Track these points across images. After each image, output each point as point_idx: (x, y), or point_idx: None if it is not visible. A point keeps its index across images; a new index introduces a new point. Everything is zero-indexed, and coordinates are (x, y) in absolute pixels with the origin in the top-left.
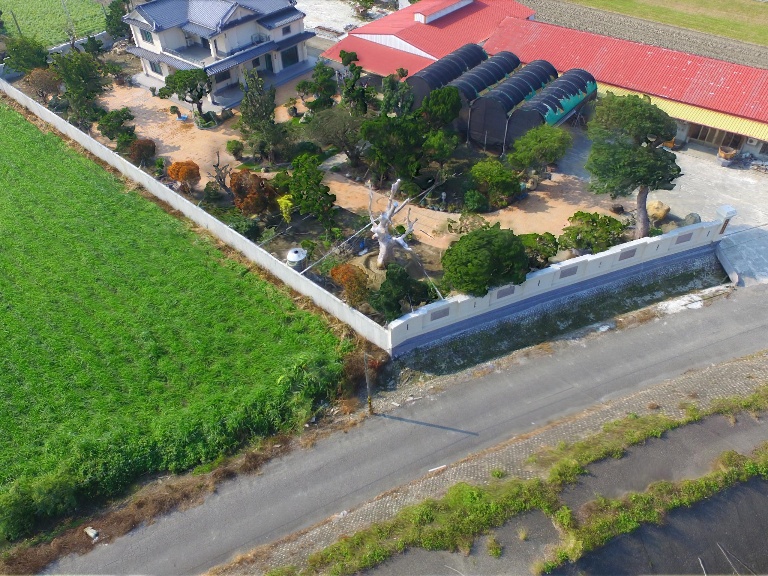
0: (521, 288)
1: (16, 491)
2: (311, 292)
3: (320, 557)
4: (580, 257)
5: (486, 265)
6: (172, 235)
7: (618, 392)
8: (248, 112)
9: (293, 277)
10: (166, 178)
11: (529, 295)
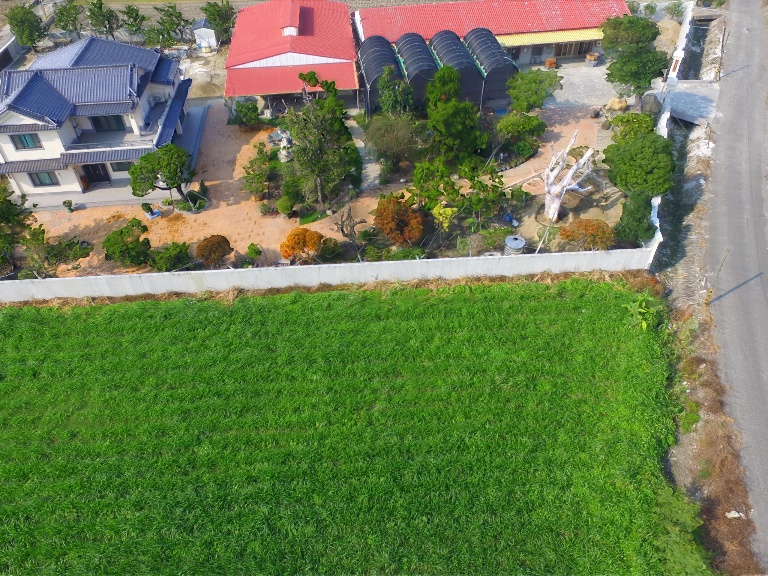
0: None
1: (685, 533)
2: (550, 264)
3: None
4: None
5: None
6: (360, 303)
7: (765, 207)
8: (306, 156)
9: (525, 262)
10: (262, 265)
11: None
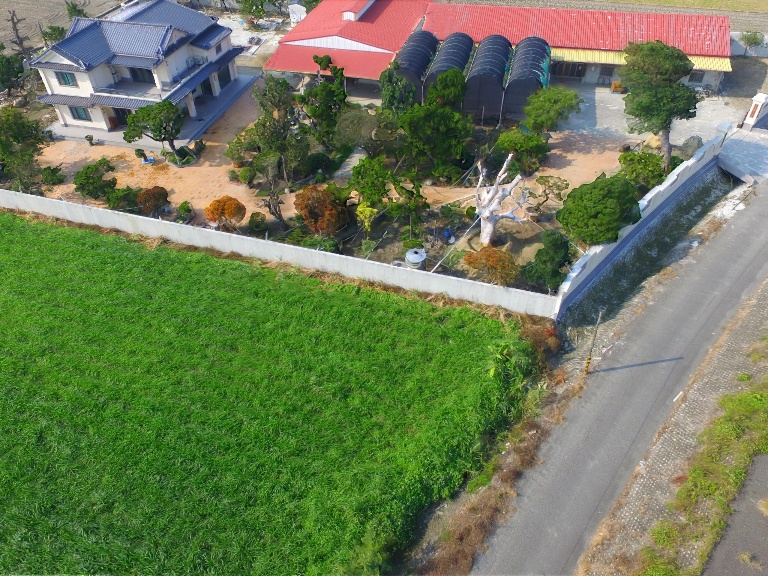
0: (623, 229)
1: None
2: (446, 287)
3: (687, 500)
4: (654, 190)
5: (618, 211)
6: (250, 277)
7: (749, 288)
8: (266, 132)
9: (420, 278)
10: (193, 223)
11: (626, 234)
